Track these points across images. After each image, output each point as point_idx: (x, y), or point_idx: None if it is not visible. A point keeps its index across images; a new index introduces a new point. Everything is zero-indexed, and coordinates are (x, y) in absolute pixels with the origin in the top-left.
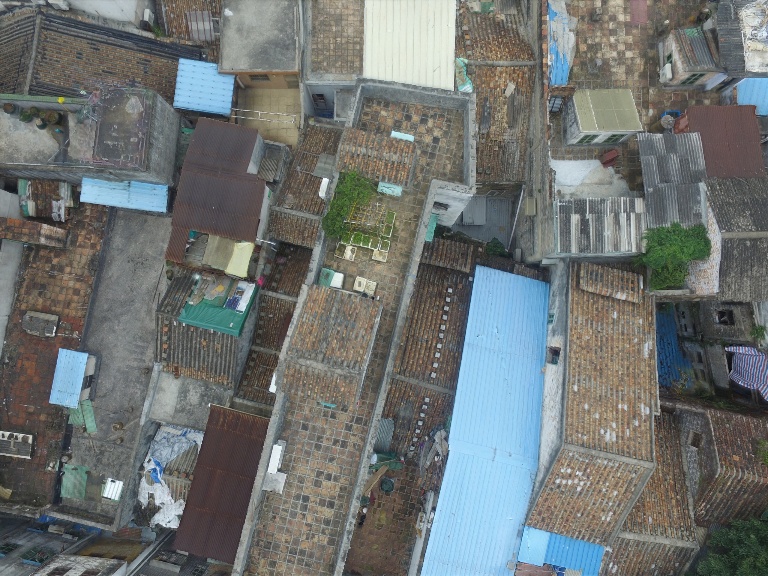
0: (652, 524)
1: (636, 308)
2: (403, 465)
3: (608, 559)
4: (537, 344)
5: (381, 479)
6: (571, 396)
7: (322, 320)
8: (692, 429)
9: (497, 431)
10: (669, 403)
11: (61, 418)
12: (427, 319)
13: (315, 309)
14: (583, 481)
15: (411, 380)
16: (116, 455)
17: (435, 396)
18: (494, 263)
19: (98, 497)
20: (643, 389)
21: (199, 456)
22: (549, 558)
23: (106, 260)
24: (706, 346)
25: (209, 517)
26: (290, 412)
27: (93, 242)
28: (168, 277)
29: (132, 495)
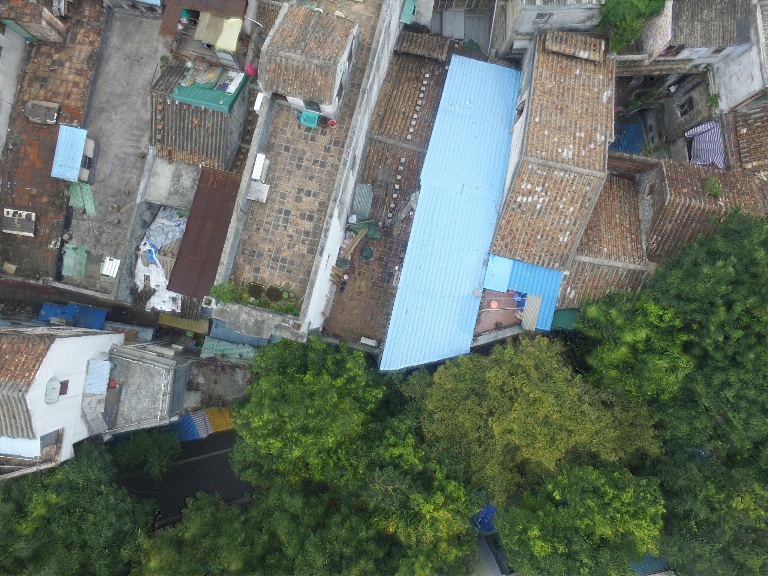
0: (607, 252)
1: (597, 68)
2: (381, 233)
3: (566, 282)
4: (506, 113)
5: (361, 249)
6: (532, 125)
7: (301, 28)
8: (648, 183)
9: (466, 172)
10: (626, 154)
11: (62, 200)
12: (405, 97)
13: (295, 21)
14: (542, 197)
15: (388, 140)
16: (114, 236)
17: (410, 157)
18: None
19: (97, 275)
20: (600, 124)
21: (191, 211)
22: (512, 285)
23: (104, 57)
24: (670, 146)
25: (200, 263)
26: (273, 135)
27: (91, 40)
28: (162, 71)
29: (129, 273)
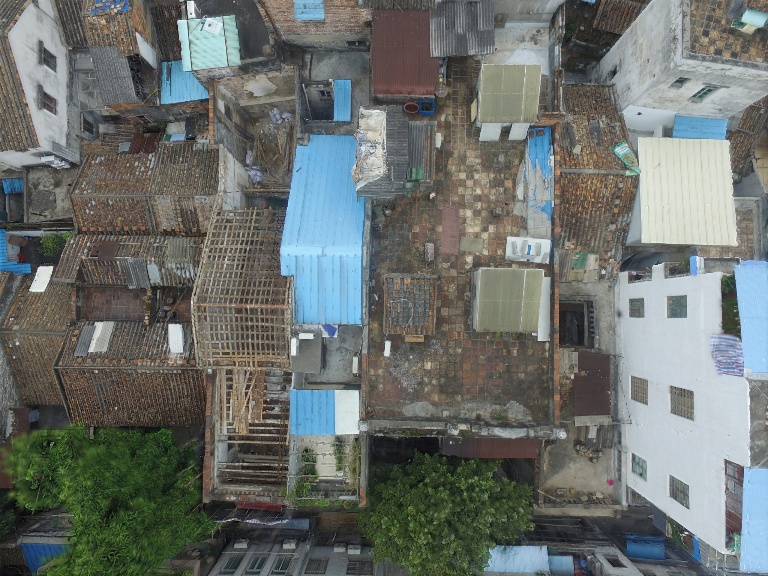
0: None
1: None
2: None
3: None
4: None
5: None
6: None
7: None
8: None
9: None
10: None
11: None
12: None
13: None
14: None
15: None
16: None
17: None
18: (570, 13)
19: None
20: None
21: None
22: None
23: None
24: None
25: None
26: None
27: None
28: None
29: None
